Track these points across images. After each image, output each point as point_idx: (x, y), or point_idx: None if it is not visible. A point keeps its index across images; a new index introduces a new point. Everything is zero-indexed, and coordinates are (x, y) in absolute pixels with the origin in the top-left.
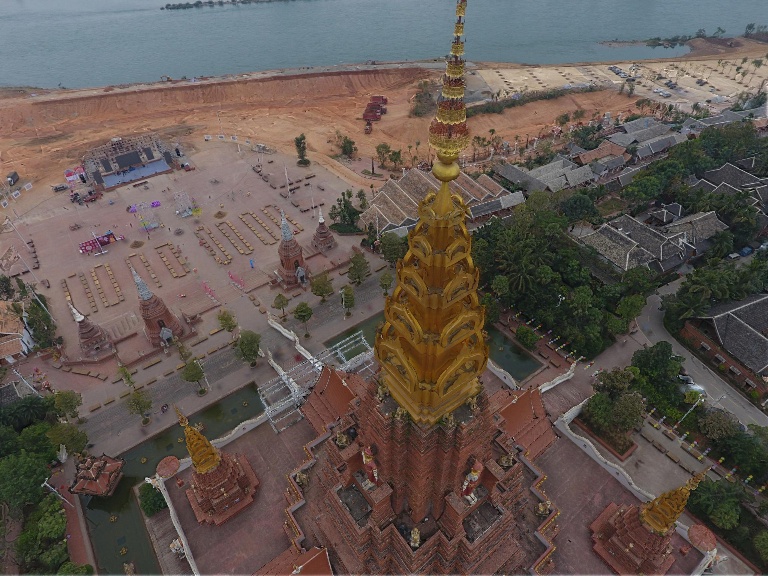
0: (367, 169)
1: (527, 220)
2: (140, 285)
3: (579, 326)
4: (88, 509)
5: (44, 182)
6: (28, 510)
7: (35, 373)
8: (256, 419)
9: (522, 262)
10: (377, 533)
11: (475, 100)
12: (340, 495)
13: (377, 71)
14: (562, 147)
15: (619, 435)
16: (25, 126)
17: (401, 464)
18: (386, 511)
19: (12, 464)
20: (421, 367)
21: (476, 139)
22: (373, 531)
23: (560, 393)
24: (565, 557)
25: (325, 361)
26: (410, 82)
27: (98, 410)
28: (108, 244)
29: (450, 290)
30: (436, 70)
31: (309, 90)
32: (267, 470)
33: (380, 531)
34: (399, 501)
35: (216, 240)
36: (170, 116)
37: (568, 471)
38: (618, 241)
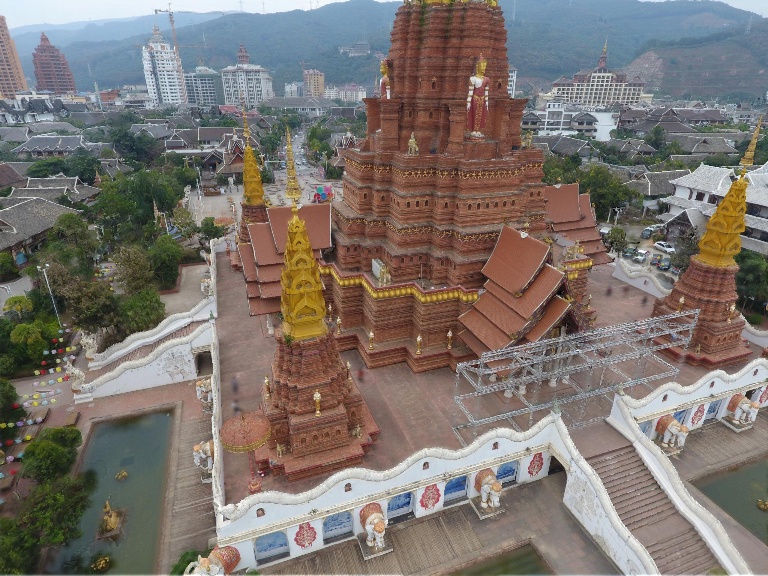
0: None
1: None
2: None
3: None
4: None
5: None
6: None
7: None
8: (693, 385)
9: None
10: None
11: None
12: None
13: None
14: None
15: None
16: None
17: None
18: None
19: None
20: None
21: None
22: None
23: None
24: None
25: (584, 567)
26: None
27: None
28: None
29: None
30: None
31: None
32: None
33: None
34: None
35: None
36: None
37: None
38: None
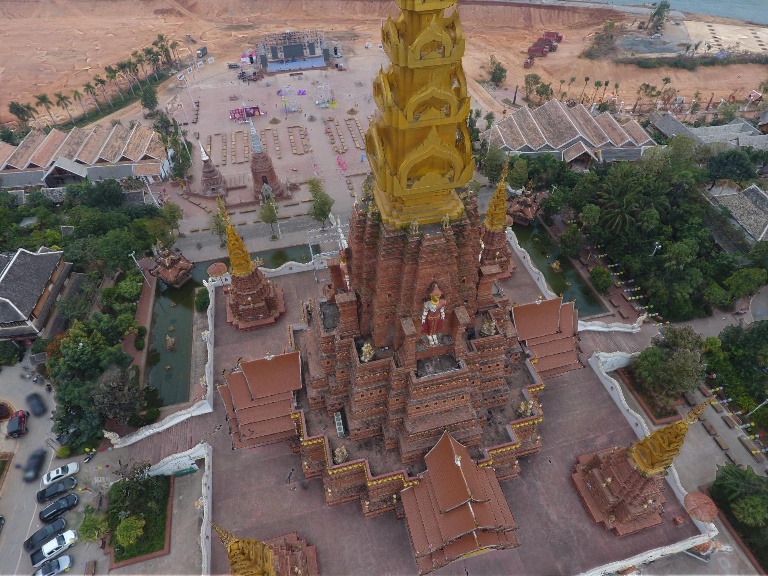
0: (509, 98)
1: (655, 163)
2: (254, 137)
3: (667, 281)
4: (162, 296)
5: (224, 59)
6: (120, 278)
7: (163, 193)
8: (303, 264)
9: (625, 197)
10: (337, 340)
11: (666, 51)
12: (322, 306)
13: (563, 7)
14: (754, 116)
15: (661, 396)
16: (226, 14)
17: (368, 272)
18: (352, 326)
19: (116, 236)
20: (393, 153)
21: (644, 87)
22: (335, 339)
23: (613, 339)
24: (538, 472)
25: None
26: (597, 24)
27: (196, 232)
28: (253, 116)
29: (418, 43)
30: (633, 15)
31: (483, 18)
32: (296, 306)
33: (340, 339)
34: (365, 320)
35: (340, 132)
36: (344, 23)
37: (581, 405)
38: (763, 207)
